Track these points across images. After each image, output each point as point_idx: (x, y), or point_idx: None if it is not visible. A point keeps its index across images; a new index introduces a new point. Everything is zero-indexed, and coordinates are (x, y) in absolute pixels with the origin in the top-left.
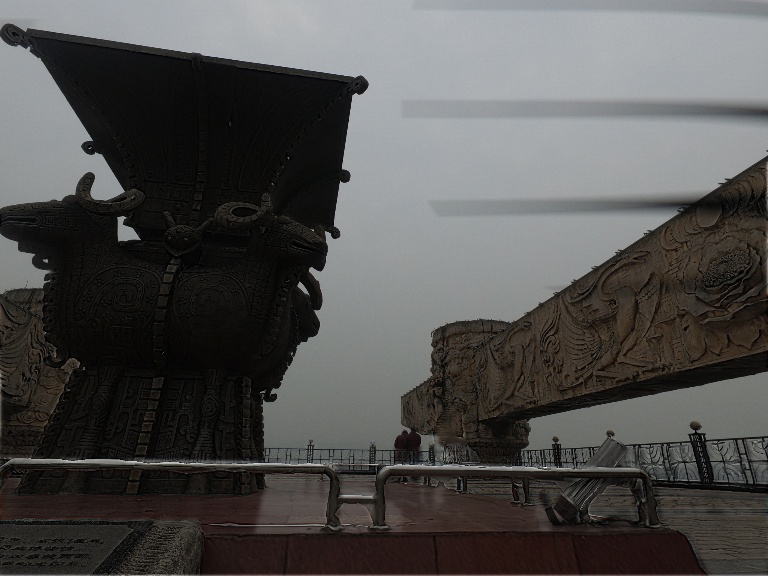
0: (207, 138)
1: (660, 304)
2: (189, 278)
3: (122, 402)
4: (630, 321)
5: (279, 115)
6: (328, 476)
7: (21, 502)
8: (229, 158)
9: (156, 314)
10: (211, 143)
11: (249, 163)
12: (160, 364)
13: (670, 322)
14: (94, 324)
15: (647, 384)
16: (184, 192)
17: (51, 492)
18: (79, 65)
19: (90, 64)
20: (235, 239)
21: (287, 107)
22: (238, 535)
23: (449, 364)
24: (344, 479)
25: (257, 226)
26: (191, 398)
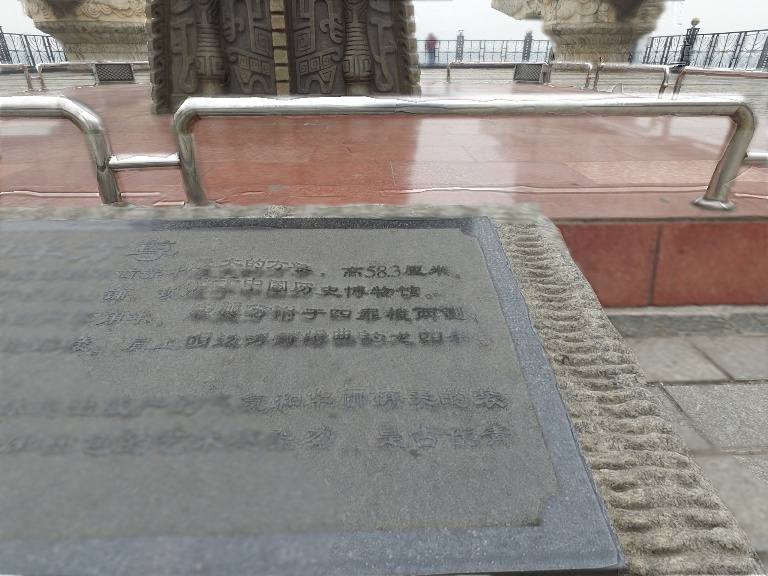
0: None
1: None
2: None
3: None
4: None
5: None
6: (737, 121)
7: None
8: None
9: None
10: None
11: None
12: None
13: None
14: None
15: None
16: None
17: None
18: None
19: None
20: None
21: None
22: (583, 220)
23: None
24: (438, 75)
25: None
26: None
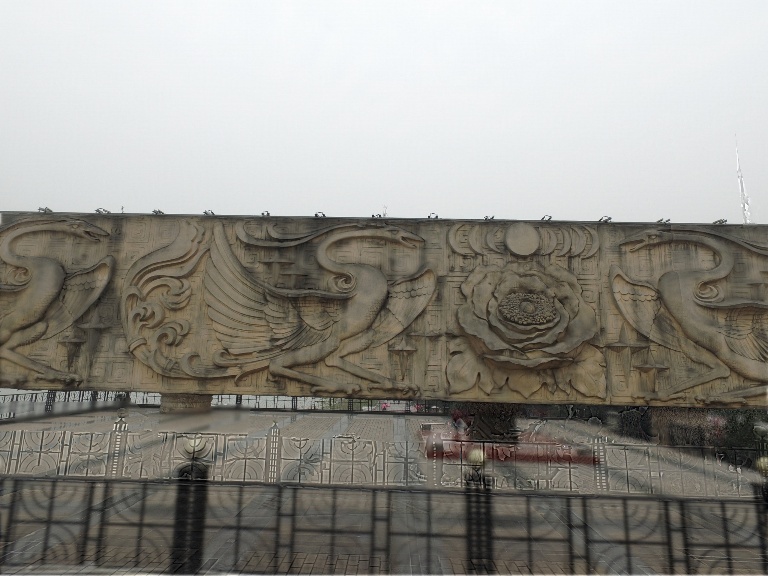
0: None
1: (425, 311)
2: None
3: None
4: (373, 316)
5: None
6: None
7: None
8: None
9: None
10: None
11: None
12: None
13: (434, 338)
14: None
15: None
16: None
17: None
18: None
19: None
20: None
21: None
22: None
23: None
24: None
25: None
26: None
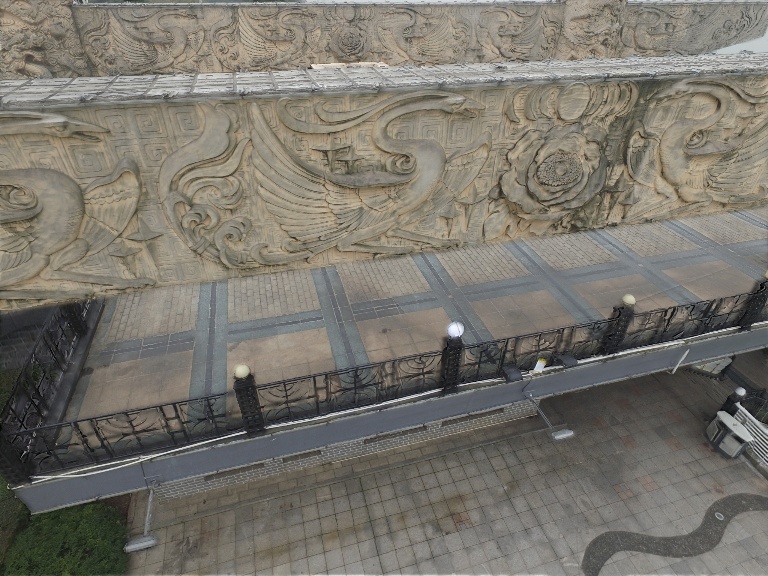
0: None
1: None
2: None
3: None
4: None
5: None
6: None
7: None
8: None
9: None
10: None
11: None
12: None
13: None
14: None
15: None
16: None
17: None
18: None
19: None
20: None
21: None
22: None
23: None
24: None
25: None
26: None
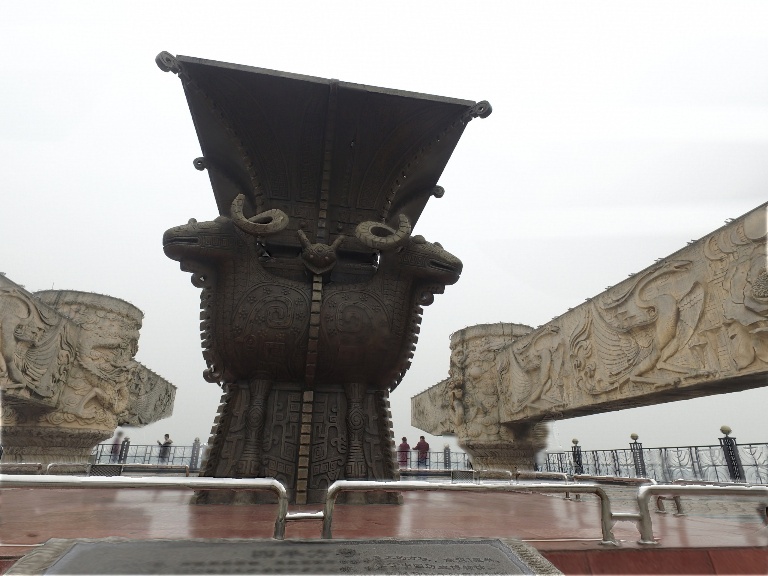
0: (331, 158)
1: (704, 312)
2: (331, 295)
3: (274, 415)
4: (671, 328)
5: (399, 136)
6: None
7: (235, 514)
8: (349, 177)
9: (310, 331)
10: (333, 162)
11: (367, 182)
12: (310, 378)
13: (715, 330)
14: (250, 340)
15: (687, 390)
16: (307, 210)
17: (223, 502)
18: (219, 88)
19: (230, 87)
20: (356, 255)
21: (408, 129)
22: (545, 551)
23: (469, 367)
24: None
25: (399, 246)
26: (337, 411)
